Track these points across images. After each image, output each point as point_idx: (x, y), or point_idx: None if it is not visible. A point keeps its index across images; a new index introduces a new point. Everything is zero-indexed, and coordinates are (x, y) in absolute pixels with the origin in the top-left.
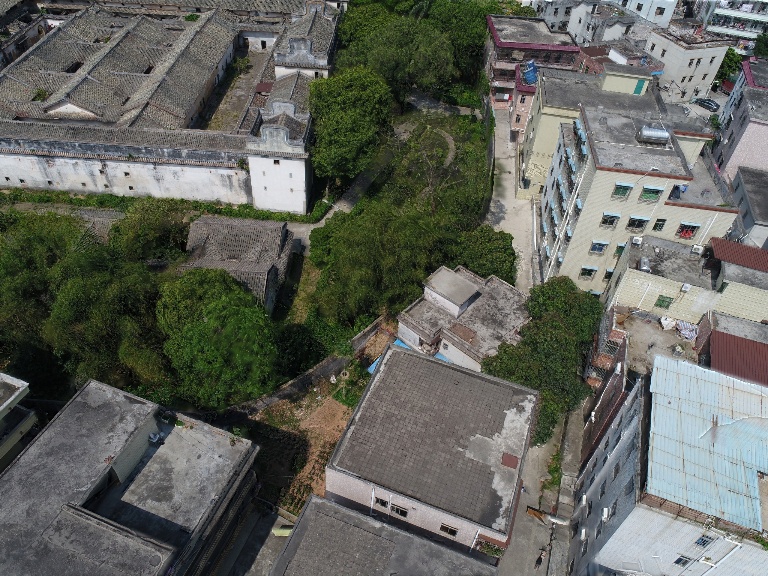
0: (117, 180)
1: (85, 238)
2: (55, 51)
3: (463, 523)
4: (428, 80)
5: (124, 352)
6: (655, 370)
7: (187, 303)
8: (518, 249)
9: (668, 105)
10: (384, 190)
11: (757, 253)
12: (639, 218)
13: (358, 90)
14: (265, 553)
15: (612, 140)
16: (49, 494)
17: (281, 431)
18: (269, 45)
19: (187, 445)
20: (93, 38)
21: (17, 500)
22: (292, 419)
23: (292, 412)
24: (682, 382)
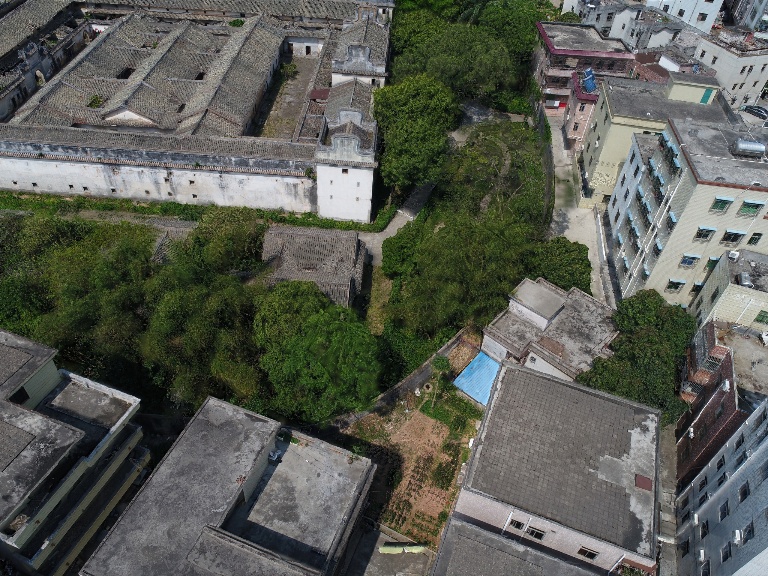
0: (181, 188)
1: (161, 248)
2: (106, 57)
3: (607, 547)
4: (488, 88)
5: (220, 366)
6: None
7: (287, 317)
8: None
9: None
10: (445, 199)
11: None
12: (736, 232)
13: (425, 99)
14: (372, 571)
15: (706, 153)
16: (187, 515)
17: (373, 445)
18: (313, 51)
19: (305, 463)
20: (140, 43)
21: (156, 521)
22: (382, 433)
23: (382, 426)
24: None
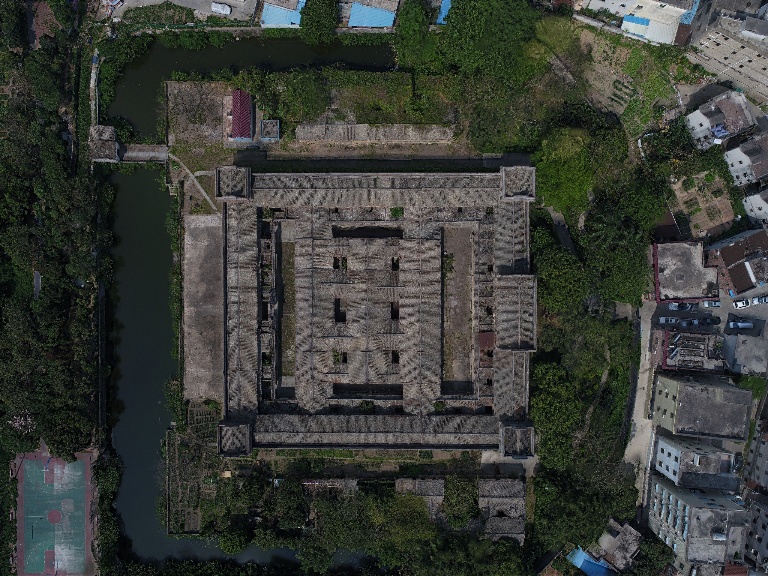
0: None
1: (432, 509)
2: (321, 300)
3: None
4: None
5: None
6: None
7: None
8: (639, 462)
9: (767, 341)
10: None
11: (742, 572)
12: None
13: None
14: None
15: (699, 535)
16: None
17: None
18: None
19: None
20: (332, 260)
21: None
22: None
23: None
24: None
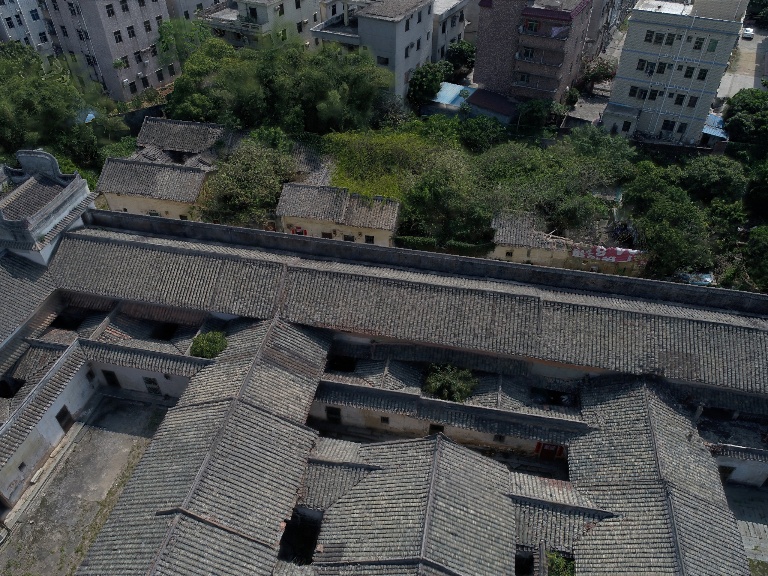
0: None
1: None
2: None
3: None
4: None
5: None
6: None
7: None
8: None
9: None
10: None
11: None
12: None
13: None
14: None
15: None
16: None
17: None
18: None
19: None
20: None
21: None
22: None
23: None
24: None
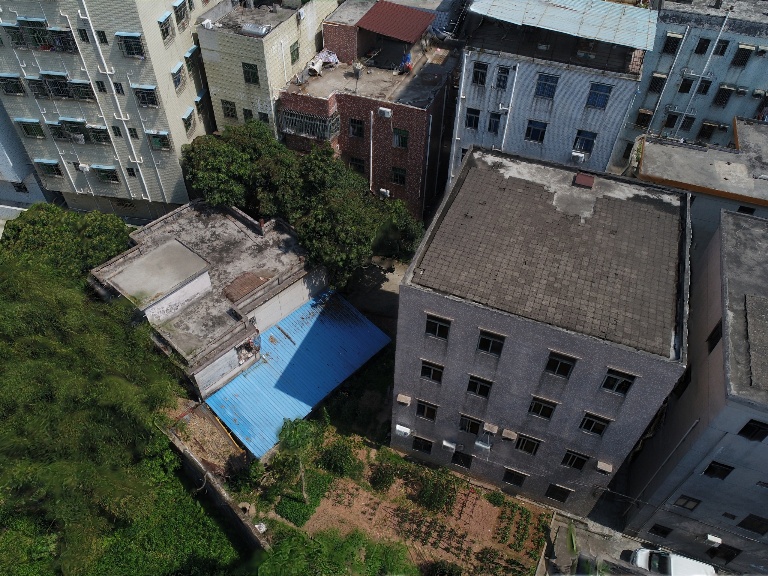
0: None
1: None
2: None
3: None
4: None
5: None
6: (491, 15)
7: None
8: None
9: None
10: None
11: None
12: (181, 1)
13: None
14: None
15: None
16: None
17: None
18: None
19: None
20: None
21: None
22: None
23: None
24: (504, 6)
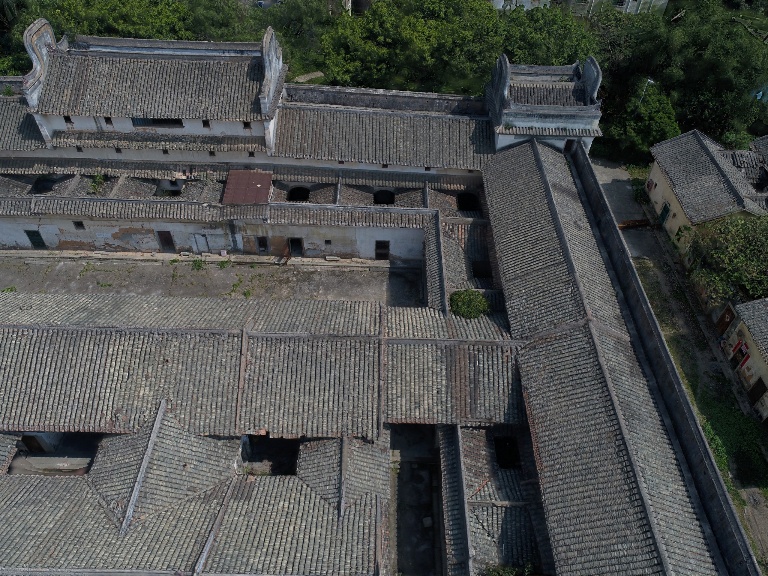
0: None
1: None
2: None
3: None
4: None
5: None
6: None
7: None
8: None
9: None
10: None
11: None
12: None
13: None
14: None
15: None
16: None
17: None
18: None
19: None
20: None
21: None
22: None
23: None
24: None
